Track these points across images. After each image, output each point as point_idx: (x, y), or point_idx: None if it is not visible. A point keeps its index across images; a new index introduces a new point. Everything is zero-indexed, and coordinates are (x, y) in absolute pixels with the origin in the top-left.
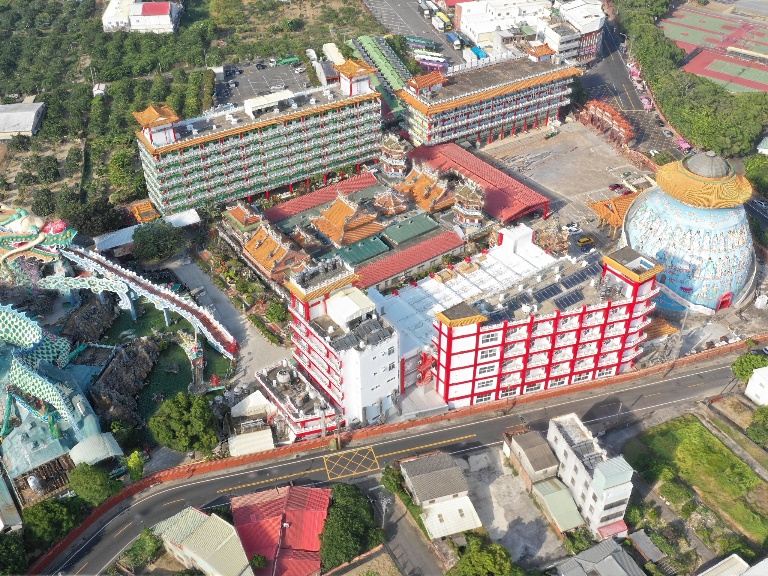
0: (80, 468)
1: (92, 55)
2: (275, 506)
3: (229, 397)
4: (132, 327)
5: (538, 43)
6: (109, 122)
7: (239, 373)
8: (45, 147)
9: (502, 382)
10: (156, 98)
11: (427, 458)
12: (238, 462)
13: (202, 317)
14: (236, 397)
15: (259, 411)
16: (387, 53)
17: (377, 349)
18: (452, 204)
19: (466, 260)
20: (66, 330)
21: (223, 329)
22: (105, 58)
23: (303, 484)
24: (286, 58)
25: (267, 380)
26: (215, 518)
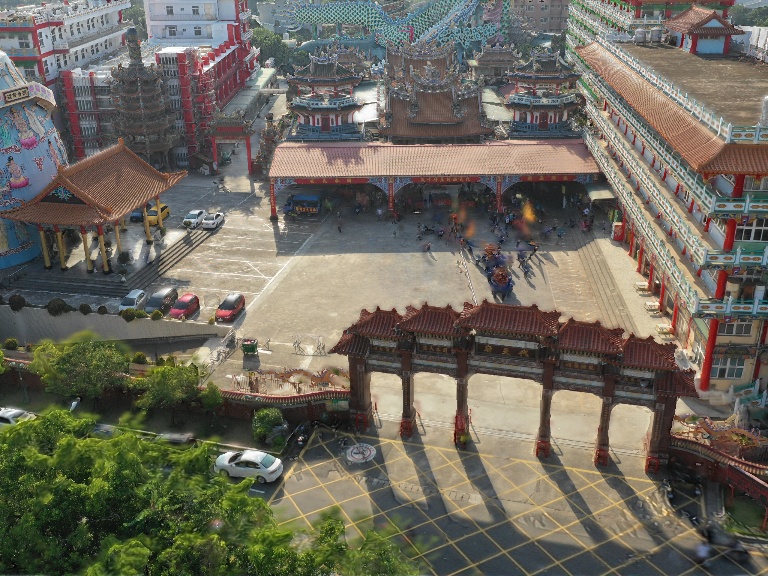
0: None
1: None
2: None
3: None
4: None
5: None
6: None
7: None
8: None
9: None
10: None
11: None
12: None
13: None
14: None
15: None
16: None
17: None
18: None
19: None
20: None
21: None
22: None
23: None
24: None
25: None
26: None
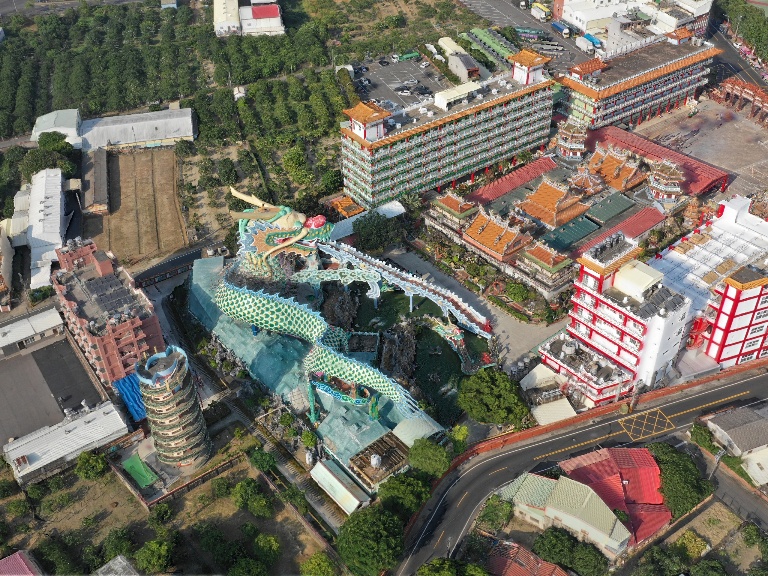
0: (422, 443)
1: (214, 60)
2: (606, 466)
3: (516, 371)
4: (377, 315)
5: (654, 27)
6: (264, 123)
7: (503, 350)
8: (209, 151)
9: (765, 341)
10: (299, 98)
11: (731, 413)
12: (543, 431)
13: (451, 301)
14: (519, 371)
15: (549, 382)
16: (506, 44)
17: (677, 315)
18: (639, 182)
19: (695, 232)
20: (328, 320)
21: (473, 311)
22: (227, 62)
23: (611, 446)
24: (405, 54)
25: (552, 353)
26: (565, 480)
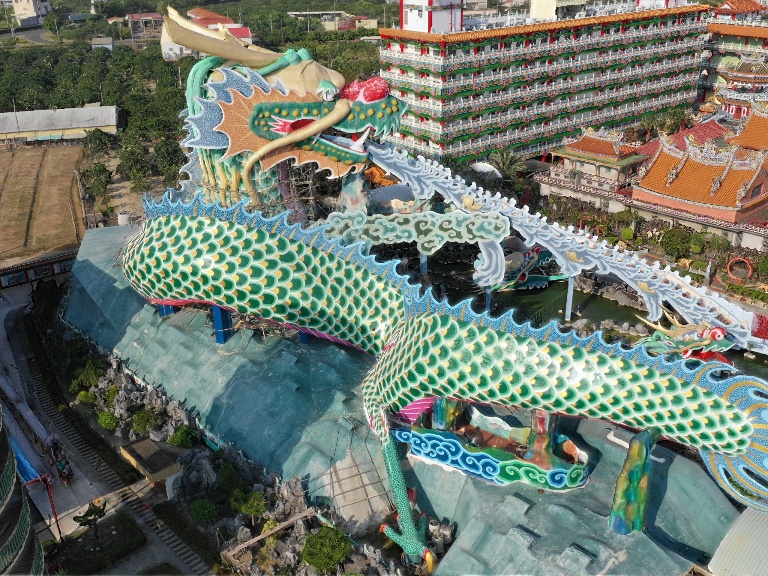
0: None
1: (158, 76)
2: None
3: None
4: None
5: None
6: None
7: None
8: None
9: None
10: None
11: None
12: None
13: None
14: None
15: None
16: None
17: None
18: None
19: None
20: None
21: (720, 301)
22: None
23: None
24: None
25: None
26: None
